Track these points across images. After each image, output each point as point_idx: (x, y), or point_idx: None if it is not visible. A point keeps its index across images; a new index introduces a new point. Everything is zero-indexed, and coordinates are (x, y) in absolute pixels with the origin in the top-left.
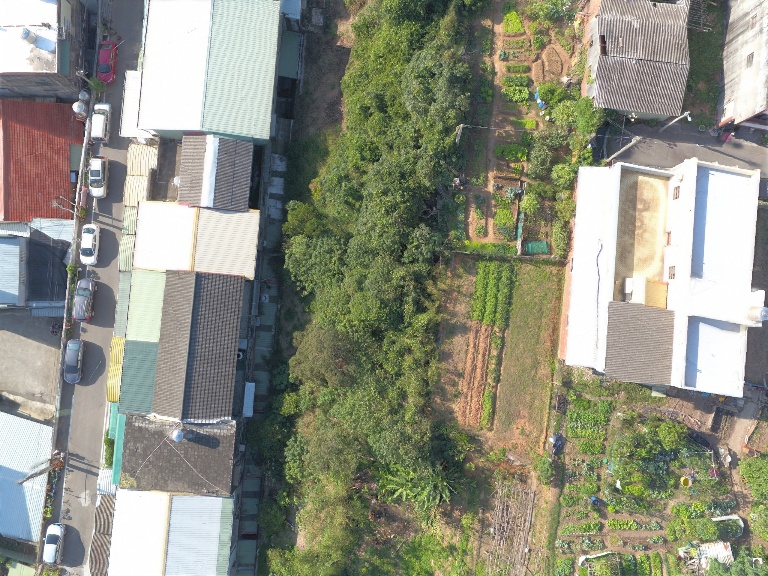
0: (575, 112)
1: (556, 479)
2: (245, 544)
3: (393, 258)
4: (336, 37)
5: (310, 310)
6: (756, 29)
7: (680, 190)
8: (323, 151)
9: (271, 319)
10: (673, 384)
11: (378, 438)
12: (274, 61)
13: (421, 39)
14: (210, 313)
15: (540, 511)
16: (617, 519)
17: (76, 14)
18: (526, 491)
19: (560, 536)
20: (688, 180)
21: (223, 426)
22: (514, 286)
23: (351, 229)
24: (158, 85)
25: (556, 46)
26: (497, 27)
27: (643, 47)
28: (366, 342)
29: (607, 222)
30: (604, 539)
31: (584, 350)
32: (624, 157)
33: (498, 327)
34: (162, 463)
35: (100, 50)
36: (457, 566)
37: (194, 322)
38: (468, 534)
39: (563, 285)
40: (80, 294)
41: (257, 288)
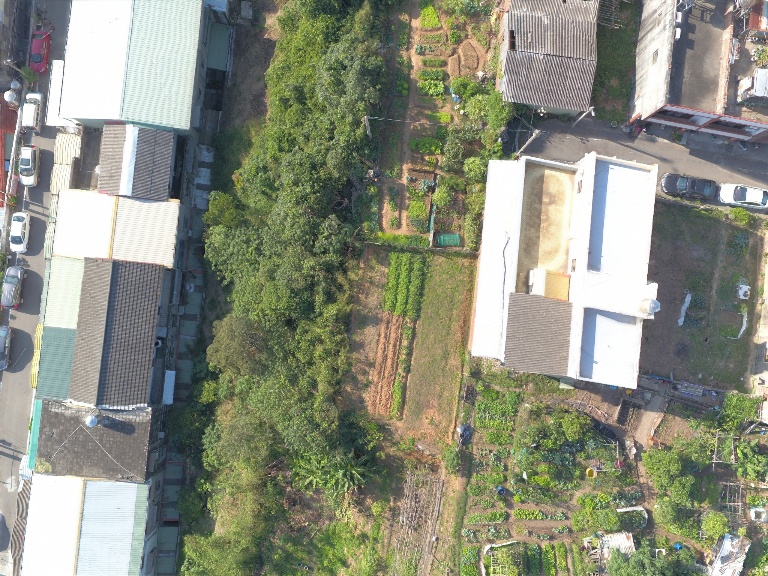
0: (487, 106)
1: (463, 469)
2: (166, 531)
3: (306, 248)
4: (264, 30)
5: (231, 300)
6: (661, 26)
7: (582, 184)
8: (247, 142)
9: (196, 308)
10: (569, 375)
11: (287, 426)
12: (195, 52)
13: (337, 32)
14: (127, 301)
15: (448, 500)
16: (523, 509)
17: (10, 4)
18: (435, 480)
19: (466, 525)
20: (587, 174)
21: (139, 413)
22: (426, 277)
23: (267, 219)
24: (79, 74)
25: (473, 41)
26: (414, 21)
27: (551, 43)
28: (278, 331)
29: (513, 215)
30: (510, 528)
31: (489, 341)
32: (536, 151)
33: (409, 318)
34: (77, 448)
35: (33, 40)
36: (368, 554)
37: (110, 309)
38: (379, 522)
39: (475, 277)
40: (8, 281)
41: (179, 277)
